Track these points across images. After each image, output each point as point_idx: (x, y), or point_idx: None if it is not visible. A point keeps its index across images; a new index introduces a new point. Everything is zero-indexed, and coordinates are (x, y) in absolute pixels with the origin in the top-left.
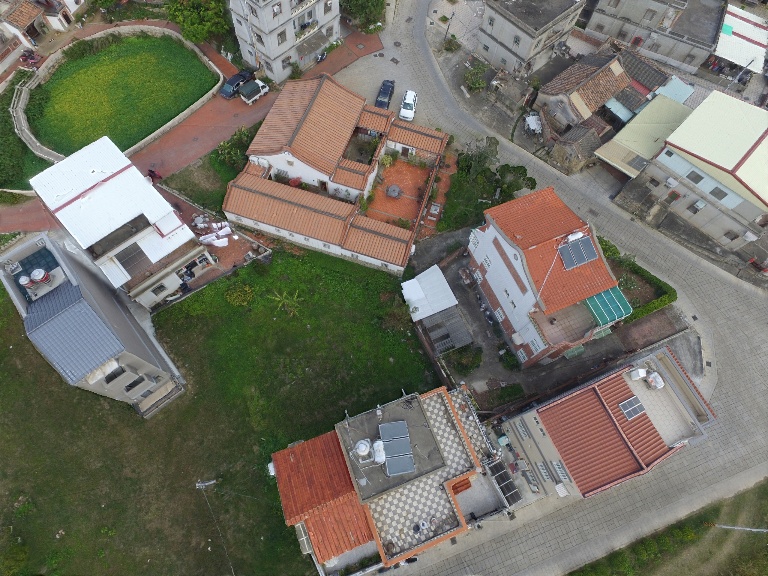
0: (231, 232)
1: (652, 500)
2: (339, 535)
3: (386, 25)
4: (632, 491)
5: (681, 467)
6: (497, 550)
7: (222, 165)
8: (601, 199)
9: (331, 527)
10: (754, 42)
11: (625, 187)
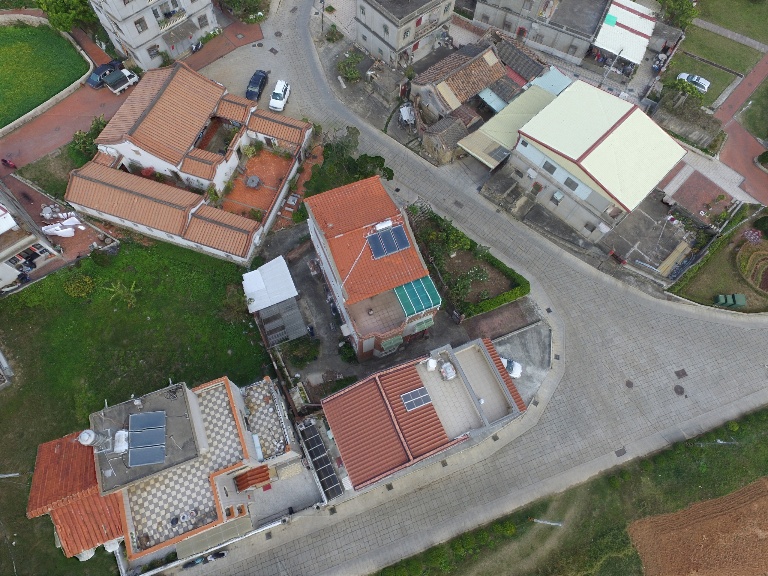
0: (80, 222)
1: (480, 495)
2: (90, 528)
3: (269, 15)
4: (460, 485)
5: (514, 461)
6: (312, 545)
7: (80, 155)
8: (468, 190)
9: (81, 520)
10: (638, 33)
11: (489, 178)
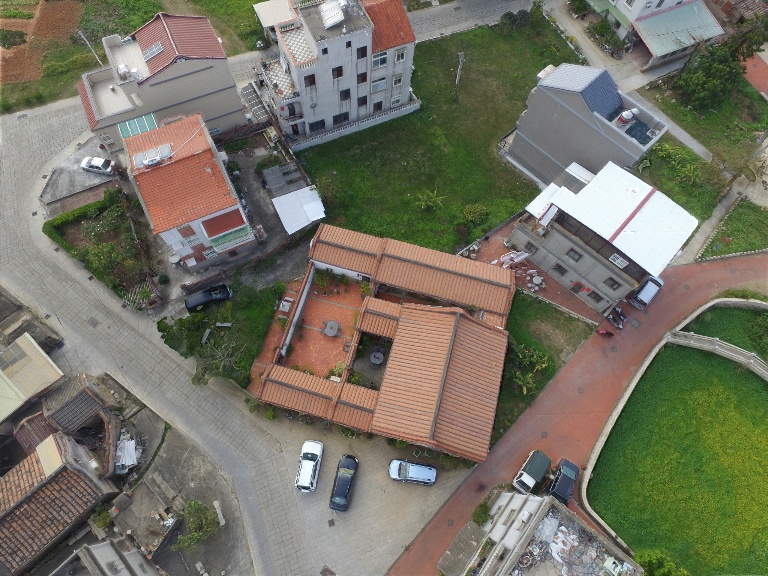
0: None
1: None
2: None
3: None
4: None
5: None
6: None
7: None
8: (75, 342)
9: None
10: None
11: (40, 343)
